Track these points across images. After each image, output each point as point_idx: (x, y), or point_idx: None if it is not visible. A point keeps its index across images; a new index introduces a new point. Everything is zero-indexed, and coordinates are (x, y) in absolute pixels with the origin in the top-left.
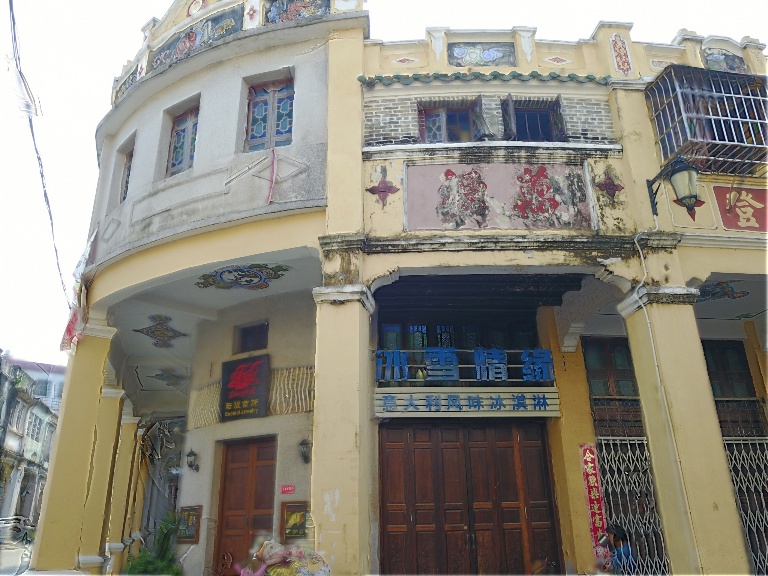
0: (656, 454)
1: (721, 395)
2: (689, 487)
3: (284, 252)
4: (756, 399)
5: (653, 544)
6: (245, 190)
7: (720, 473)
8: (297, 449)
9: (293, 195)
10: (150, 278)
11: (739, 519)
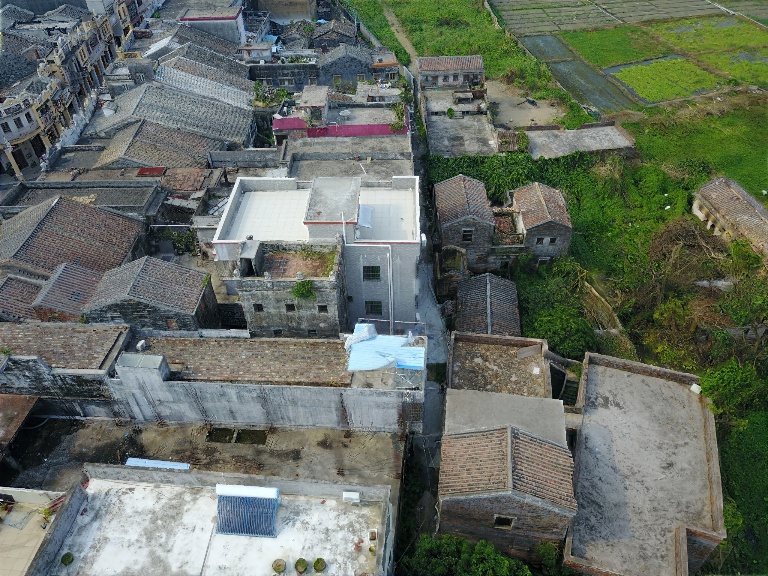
0: None
1: None
2: None
3: None
4: None
5: None
6: None
7: None
8: None
9: None
10: None
11: None
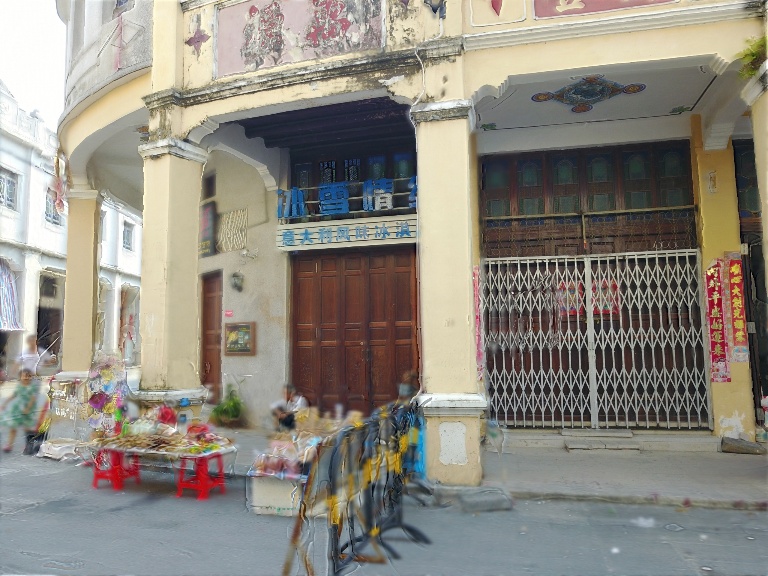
0: None
1: (645, 206)
2: (424, 306)
3: (136, 114)
4: (691, 207)
5: (530, 359)
6: (107, 60)
7: (460, 292)
8: (232, 281)
9: (134, 59)
10: (74, 149)
11: (469, 334)
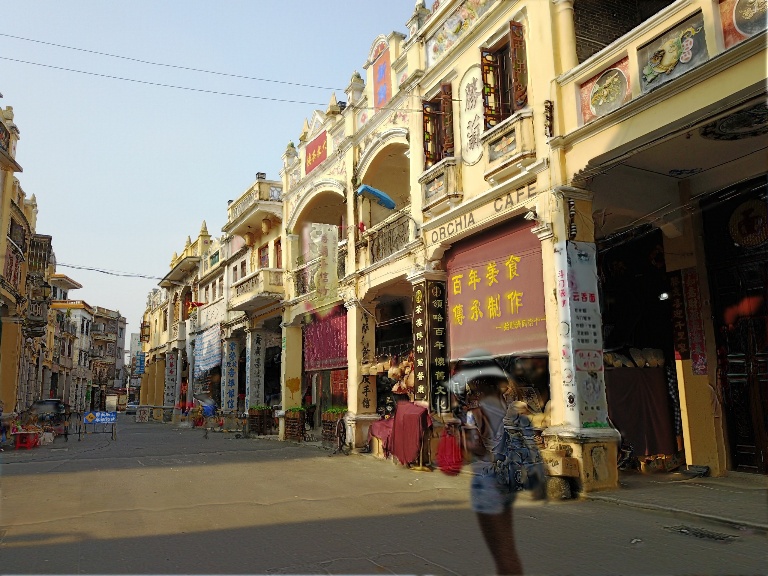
0: (2, 372)
1: None
2: None
3: None
4: None
5: None
6: None
7: None
8: None
9: None
10: None
11: None
